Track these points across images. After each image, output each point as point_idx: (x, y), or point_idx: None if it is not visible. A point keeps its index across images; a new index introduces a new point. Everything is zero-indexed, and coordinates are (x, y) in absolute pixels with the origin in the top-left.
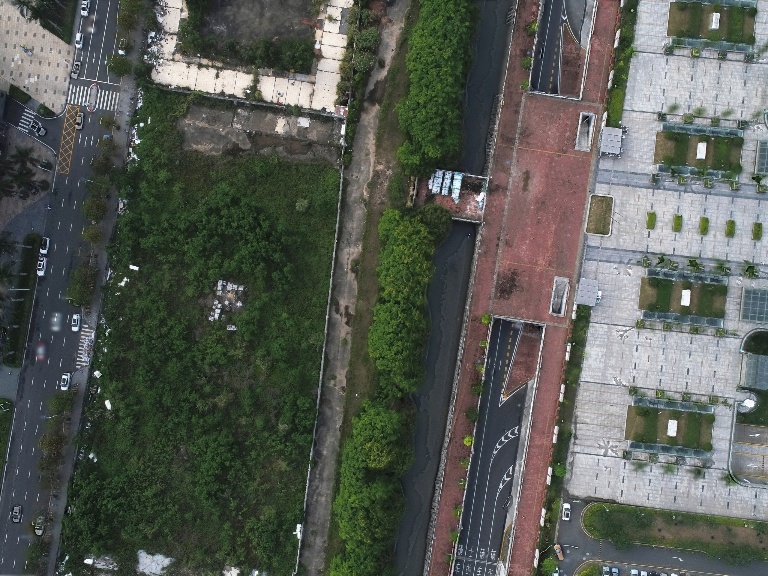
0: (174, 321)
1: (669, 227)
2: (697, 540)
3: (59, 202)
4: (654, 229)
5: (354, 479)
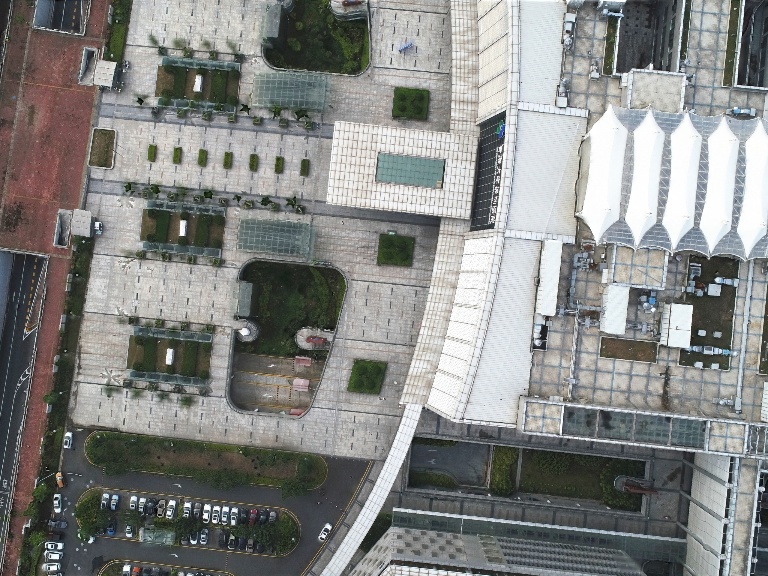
0: None
1: (170, 159)
2: (187, 466)
3: None
4: (155, 161)
5: None
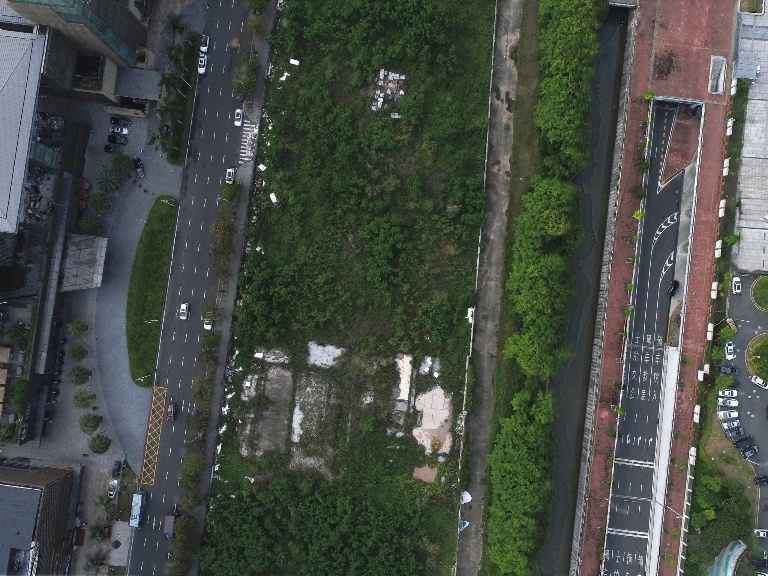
0: (339, 109)
1: None
2: None
3: (217, 1)
4: None
5: (531, 250)
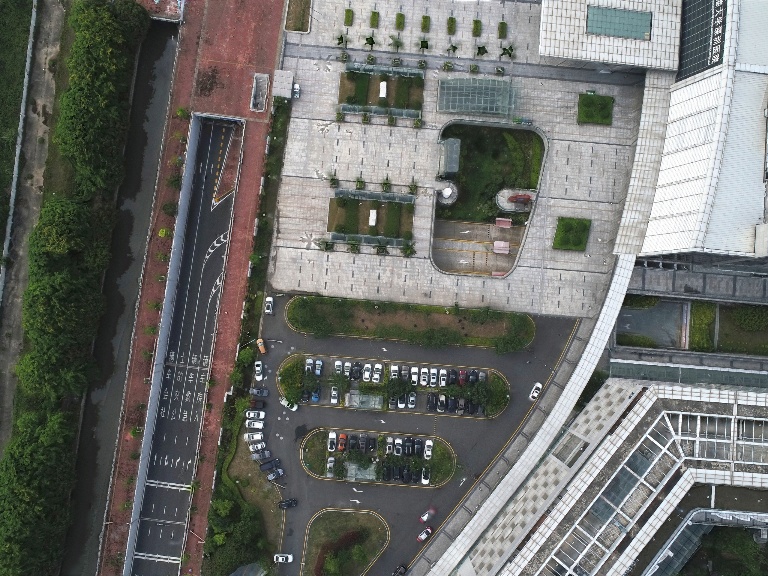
0: None
1: (367, 24)
2: (396, 325)
3: None
4: (352, 26)
5: (36, 267)
